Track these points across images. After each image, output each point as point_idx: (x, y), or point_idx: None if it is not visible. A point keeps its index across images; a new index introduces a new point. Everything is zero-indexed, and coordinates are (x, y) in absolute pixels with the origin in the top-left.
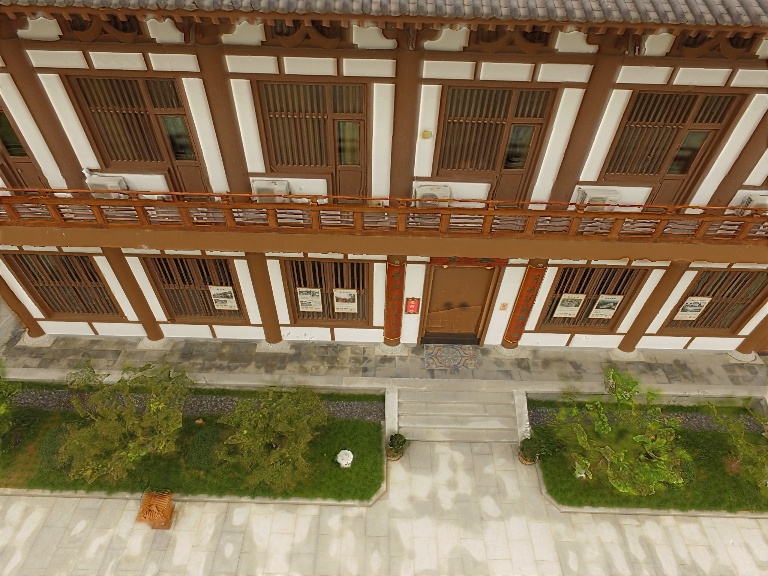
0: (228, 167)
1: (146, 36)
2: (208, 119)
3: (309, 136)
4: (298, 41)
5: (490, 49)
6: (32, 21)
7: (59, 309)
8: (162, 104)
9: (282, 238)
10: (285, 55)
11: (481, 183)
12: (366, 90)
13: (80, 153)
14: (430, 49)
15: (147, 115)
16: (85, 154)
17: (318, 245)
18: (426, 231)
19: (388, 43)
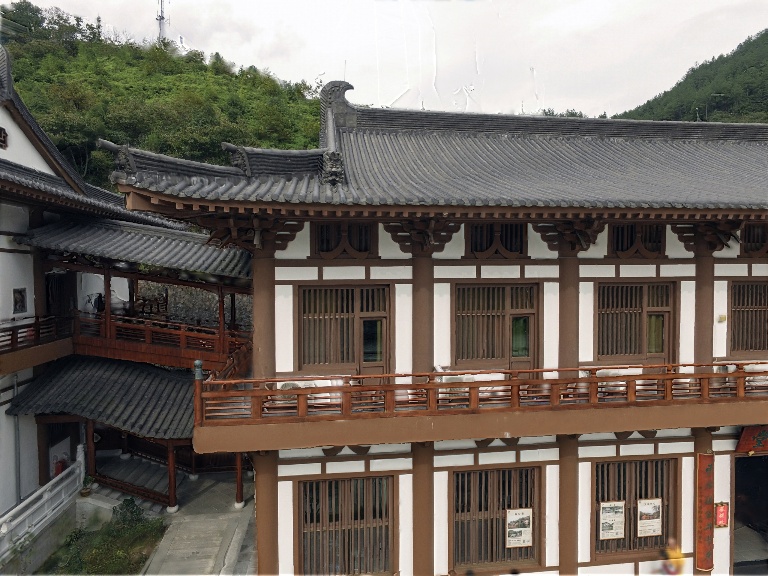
0: (567, 356)
1: (524, 255)
2: (555, 315)
3: (626, 328)
4: (631, 254)
5: (755, 255)
6: (447, 246)
7: (312, 572)
8: (517, 306)
9: (639, 412)
10: (621, 264)
11: (765, 360)
12: (675, 287)
13: (437, 352)
14: (716, 257)
15: (502, 316)
16: (442, 352)
17: (671, 418)
18: (761, 395)
19: (688, 254)
